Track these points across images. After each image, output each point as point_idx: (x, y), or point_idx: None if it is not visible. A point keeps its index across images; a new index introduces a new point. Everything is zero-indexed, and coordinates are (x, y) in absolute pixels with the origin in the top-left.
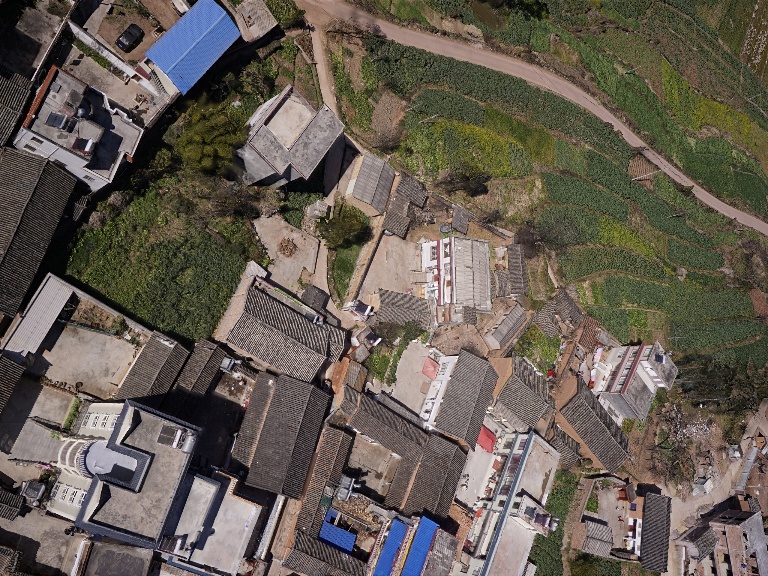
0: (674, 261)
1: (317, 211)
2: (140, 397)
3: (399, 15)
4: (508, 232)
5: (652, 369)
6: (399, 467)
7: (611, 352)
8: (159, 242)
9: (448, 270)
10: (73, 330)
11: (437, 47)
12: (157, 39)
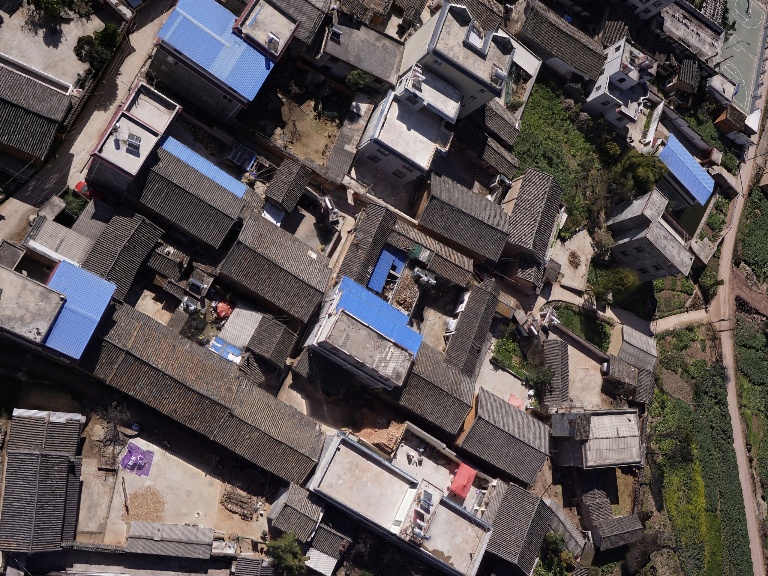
0: None
1: None
2: None
3: None
4: None
5: None
6: (437, 350)
7: None
8: None
9: None
10: None
11: (738, 452)
12: None
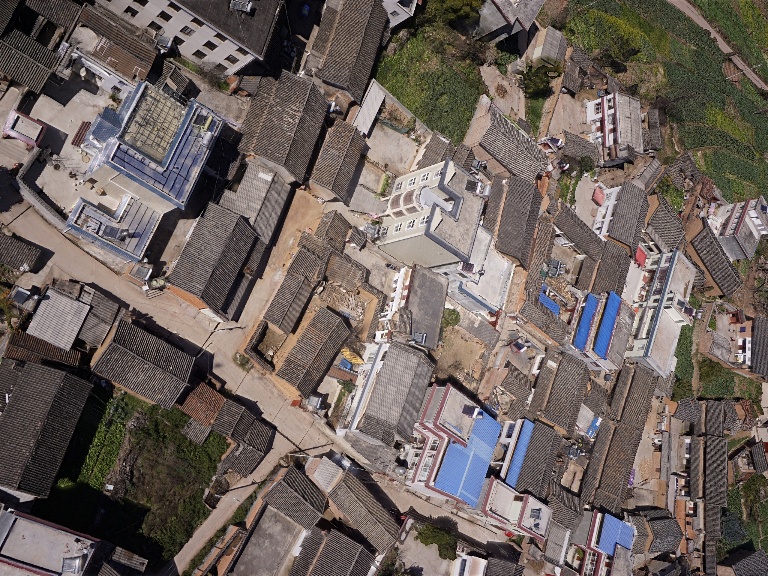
0: (760, 149)
1: (518, 66)
2: None
3: None
4: None
5: (757, 218)
6: (585, 263)
7: (720, 209)
8: (427, 72)
9: (610, 121)
10: (381, 126)
11: None
12: None
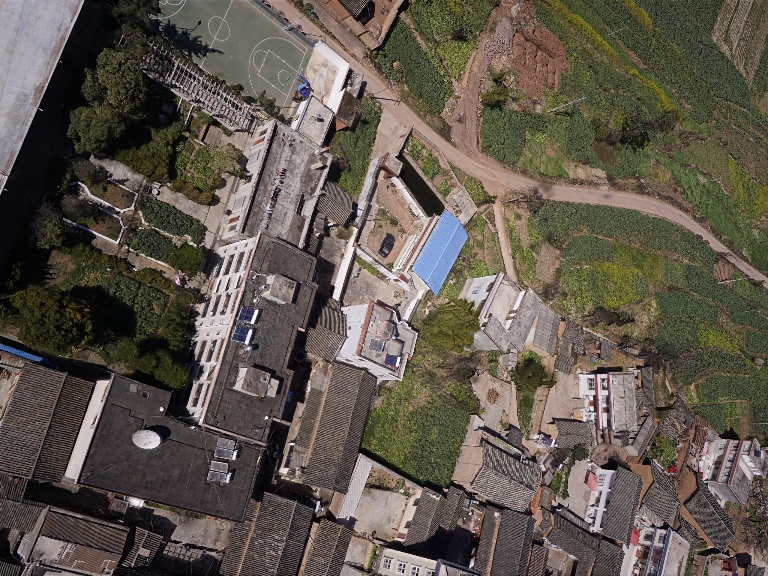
0: (751, 350)
1: (510, 362)
2: (421, 542)
3: (547, 171)
4: (634, 350)
5: (751, 461)
6: (578, 568)
7: (712, 443)
8: (416, 410)
9: (604, 399)
10: (368, 491)
11: (577, 196)
12: (403, 241)
